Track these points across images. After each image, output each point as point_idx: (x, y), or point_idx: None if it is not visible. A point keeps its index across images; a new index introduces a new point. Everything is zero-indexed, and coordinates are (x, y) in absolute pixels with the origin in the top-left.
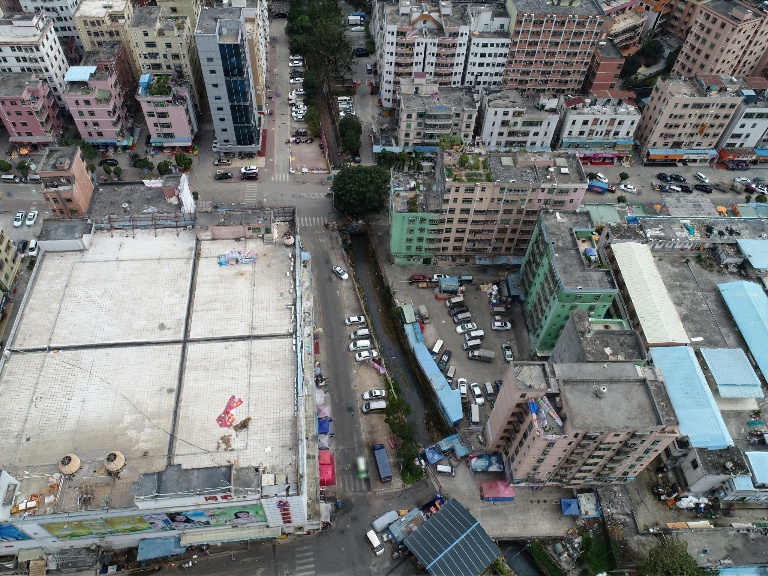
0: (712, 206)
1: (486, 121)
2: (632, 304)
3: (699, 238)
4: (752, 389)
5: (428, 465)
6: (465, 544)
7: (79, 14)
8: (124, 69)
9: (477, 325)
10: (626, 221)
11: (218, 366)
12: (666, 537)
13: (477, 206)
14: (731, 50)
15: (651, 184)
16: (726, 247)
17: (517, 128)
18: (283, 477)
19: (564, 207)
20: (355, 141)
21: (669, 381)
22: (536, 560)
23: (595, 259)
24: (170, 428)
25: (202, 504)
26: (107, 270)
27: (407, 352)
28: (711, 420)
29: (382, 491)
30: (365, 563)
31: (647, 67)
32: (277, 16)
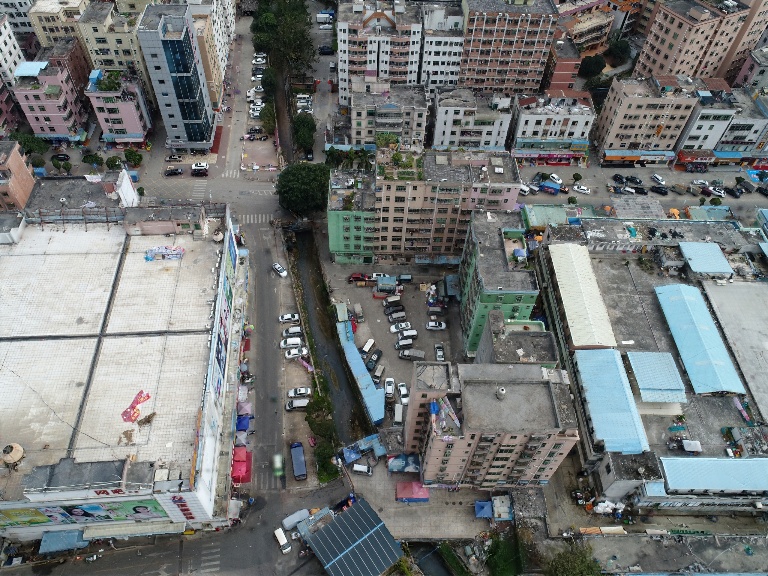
0: (661, 208)
1: (437, 120)
2: (563, 306)
3: (640, 240)
4: (675, 394)
5: (343, 464)
6: (367, 544)
7: (34, 10)
8: (79, 65)
9: (412, 325)
10: (568, 222)
11: (130, 361)
12: (576, 542)
13: (411, 205)
14: (690, 50)
15: (606, 185)
16: (668, 250)
17: (469, 127)
18: (177, 473)
19: (499, 207)
20: (308, 139)
21: (591, 384)
22: (446, 562)
23: (523, 260)
24: (74, 422)
25: (94, 498)
26: (33, 264)
27: (340, 351)
28: (629, 424)
29: (297, 489)
30: (271, 561)
31: (613, 67)
32: (246, 14)
